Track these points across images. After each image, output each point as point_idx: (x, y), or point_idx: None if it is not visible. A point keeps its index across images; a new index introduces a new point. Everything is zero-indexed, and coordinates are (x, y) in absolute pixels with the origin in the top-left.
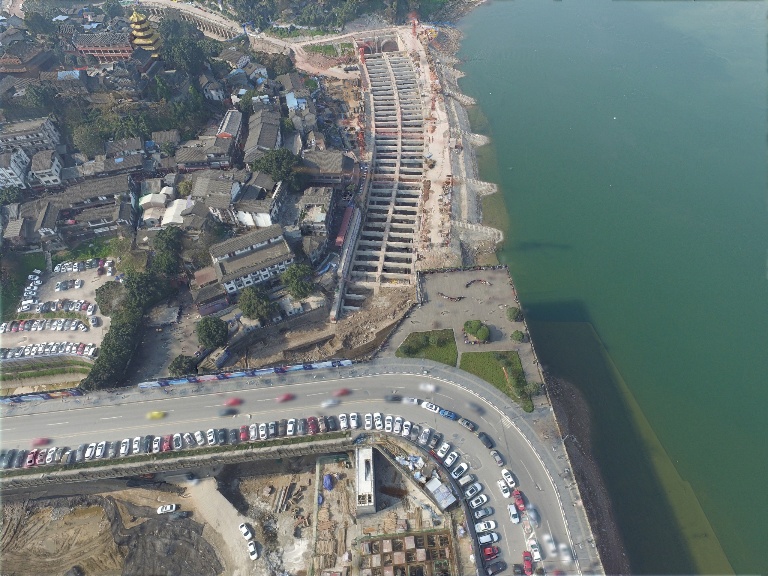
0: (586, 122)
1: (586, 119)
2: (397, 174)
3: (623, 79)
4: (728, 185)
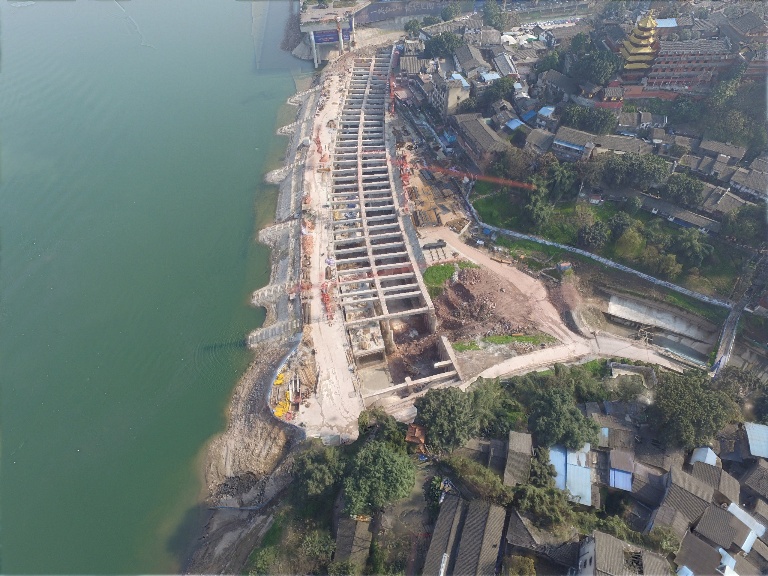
0: (144, 202)
1: (140, 207)
2: (362, 115)
3: (24, 278)
4: (82, 144)
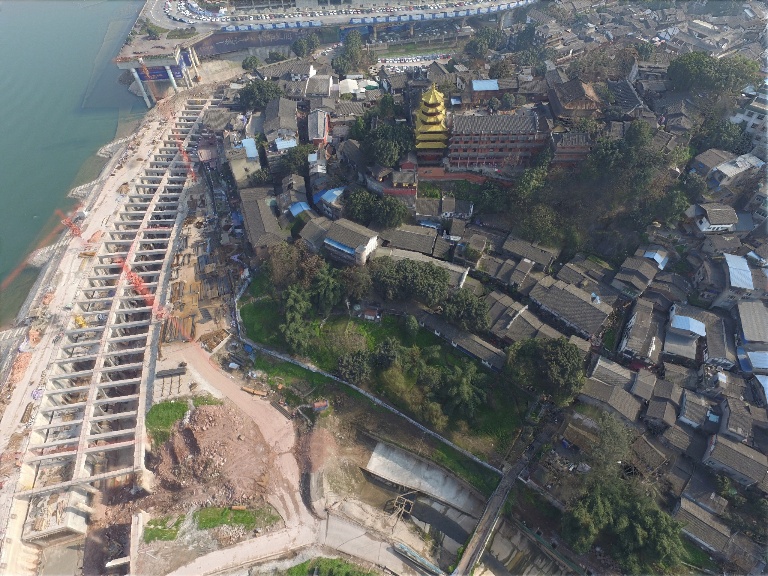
0: None
1: None
2: (165, 176)
3: None
4: None
